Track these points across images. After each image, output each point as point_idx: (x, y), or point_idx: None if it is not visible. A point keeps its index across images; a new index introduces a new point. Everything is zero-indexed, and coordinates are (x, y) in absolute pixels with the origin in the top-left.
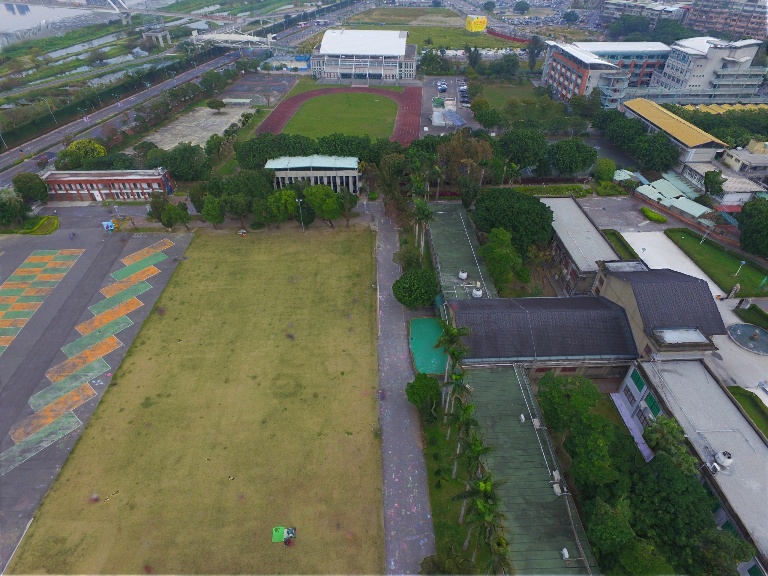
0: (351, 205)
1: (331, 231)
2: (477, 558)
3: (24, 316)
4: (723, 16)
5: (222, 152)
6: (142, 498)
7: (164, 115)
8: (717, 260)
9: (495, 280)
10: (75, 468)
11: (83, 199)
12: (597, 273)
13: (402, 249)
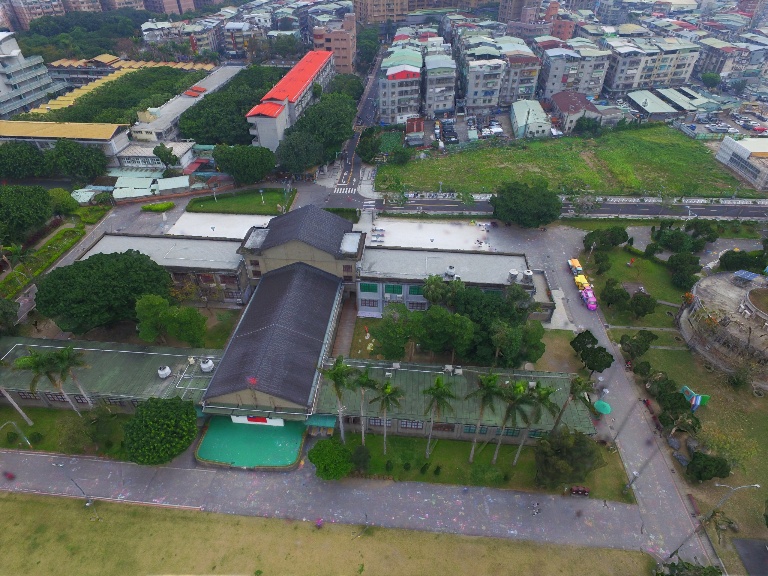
0: None
1: None
2: (500, 455)
3: None
4: None
5: None
6: None
7: None
8: (241, 203)
9: (196, 342)
10: None
11: None
12: (244, 261)
13: (63, 430)
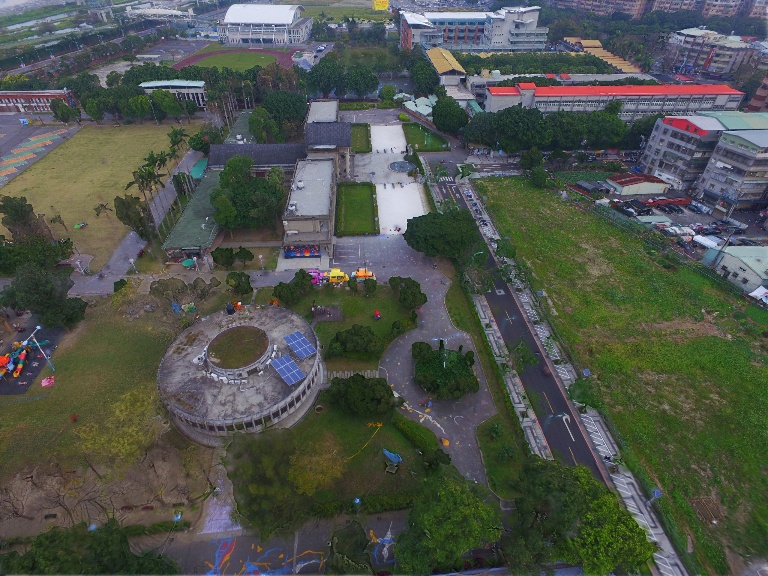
0: (192, 108)
1: (177, 125)
2: None
3: None
4: None
5: None
6: None
7: (87, 65)
8: (422, 137)
9: (256, 138)
10: None
11: (11, 111)
12: None
13: None
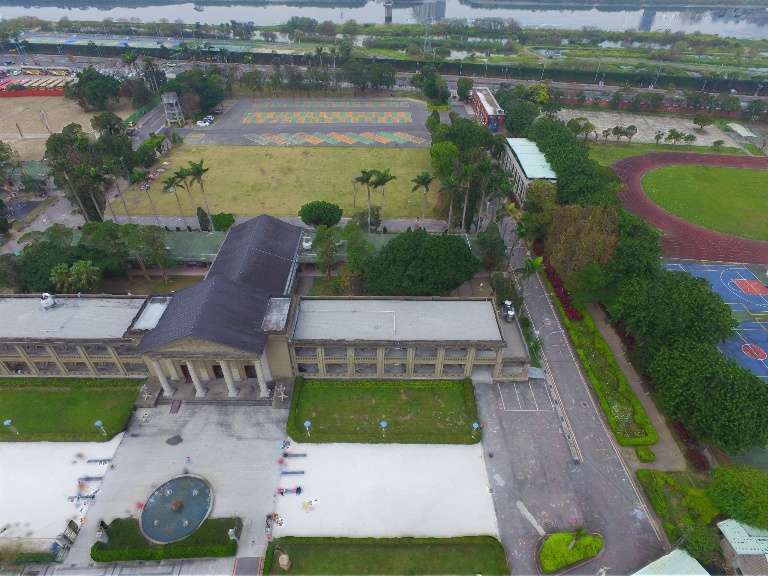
0: None
1: None
2: None
3: (346, 121)
4: None
5: (592, 142)
6: (213, 161)
7: (653, 107)
8: None
9: None
10: (238, 147)
11: None
12: None
13: None
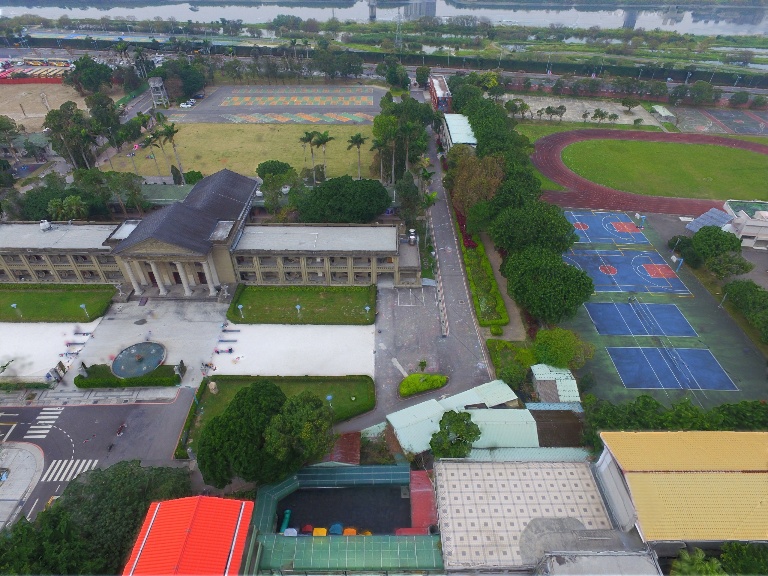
0: None
1: None
2: None
3: None
4: None
5: (529, 120)
6: None
7: (591, 93)
8: None
9: None
10: None
11: None
12: None
13: None
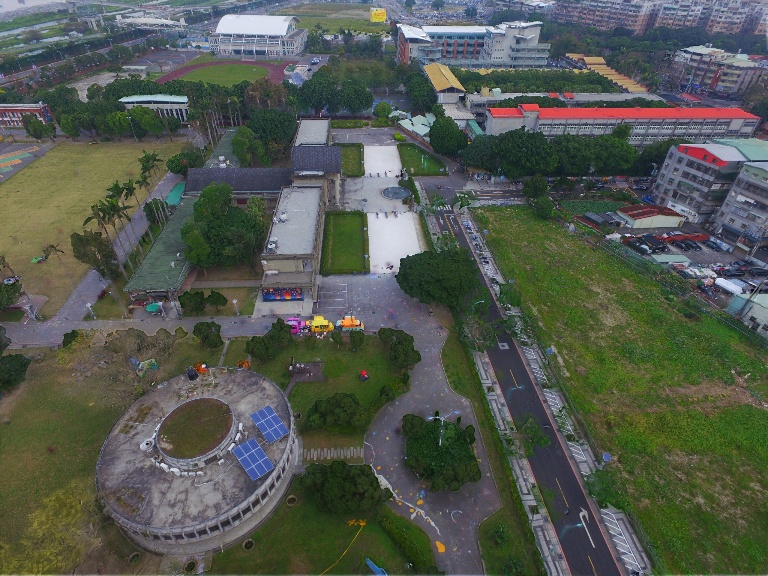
0: (174, 126)
1: (158, 143)
2: None
3: None
4: (577, 10)
5: None
6: None
7: (69, 76)
8: (418, 159)
9: (240, 160)
10: None
11: None
12: None
13: None
